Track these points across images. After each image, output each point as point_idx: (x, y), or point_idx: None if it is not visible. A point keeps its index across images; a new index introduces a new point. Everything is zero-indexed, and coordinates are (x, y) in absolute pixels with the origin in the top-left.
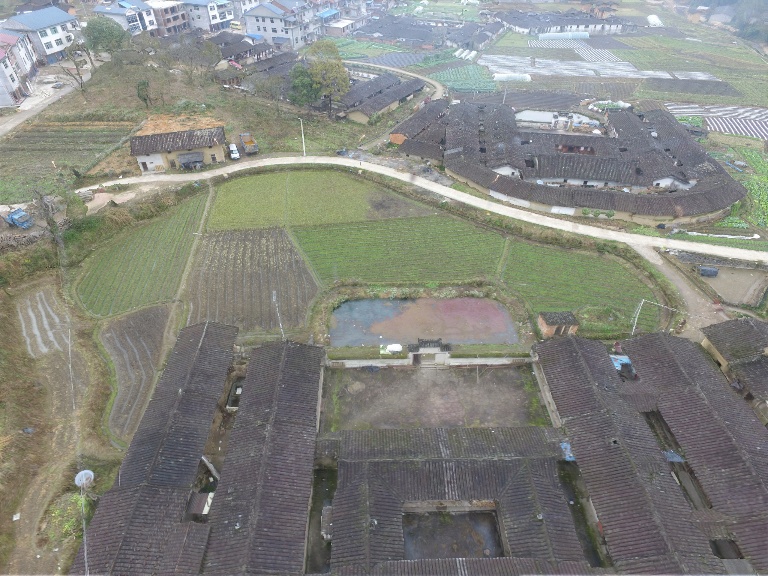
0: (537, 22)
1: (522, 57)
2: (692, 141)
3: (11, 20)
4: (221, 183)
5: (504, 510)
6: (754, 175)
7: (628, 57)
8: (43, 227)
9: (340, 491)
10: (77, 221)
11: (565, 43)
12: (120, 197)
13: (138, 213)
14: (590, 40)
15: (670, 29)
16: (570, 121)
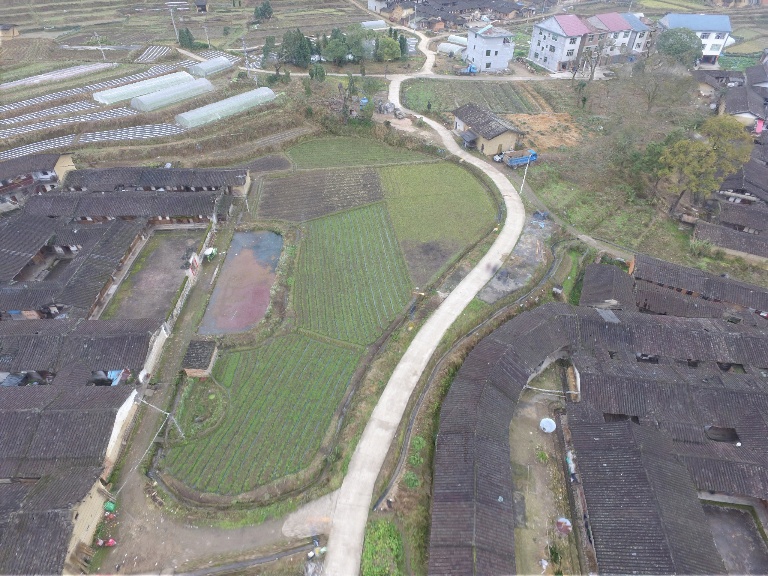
0: None
1: None
2: None
3: (667, 16)
4: (452, 162)
5: None
6: None
7: None
8: None
9: None
10: (363, 118)
11: None
12: (408, 127)
13: (389, 137)
14: None
15: None
16: None
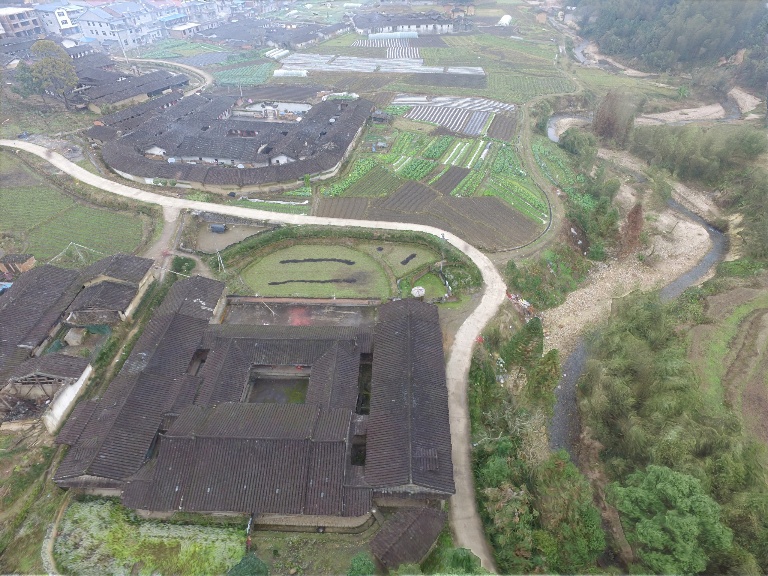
0: (371, 23)
1: (328, 55)
2: (350, 125)
3: None
4: None
5: None
6: (381, 154)
7: (429, 54)
8: None
9: None
10: None
11: (388, 42)
12: None
13: None
14: (416, 39)
15: (508, 28)
16: (276, 110)
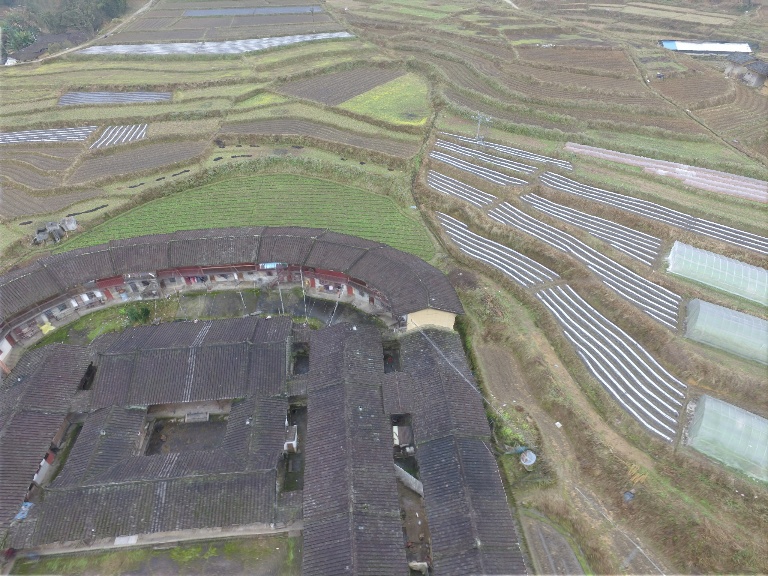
0: None
1: None
2: None
3: None
4: None
5: (131, 447)
6: None
7: None
8: None
9: (277, 450)
10: None
11: None
12: None
13: None
14: None
15: None
16: None
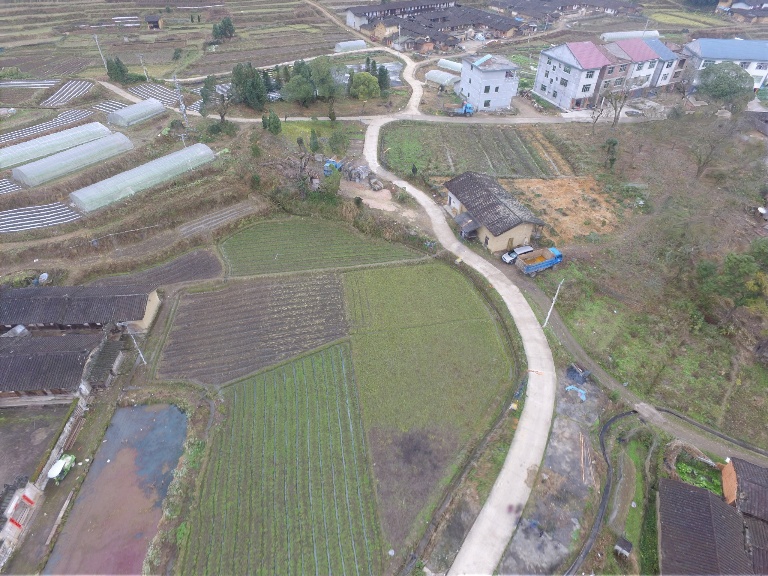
0: None
1: None
2: None
3: (697, 41)
4: (445, 262)
5: None
6: None
7: None
8: None
9: None
10: (327, 191)
11: None
12: (387, 204)
13: (360, 221)
14: None
15: None
16: None
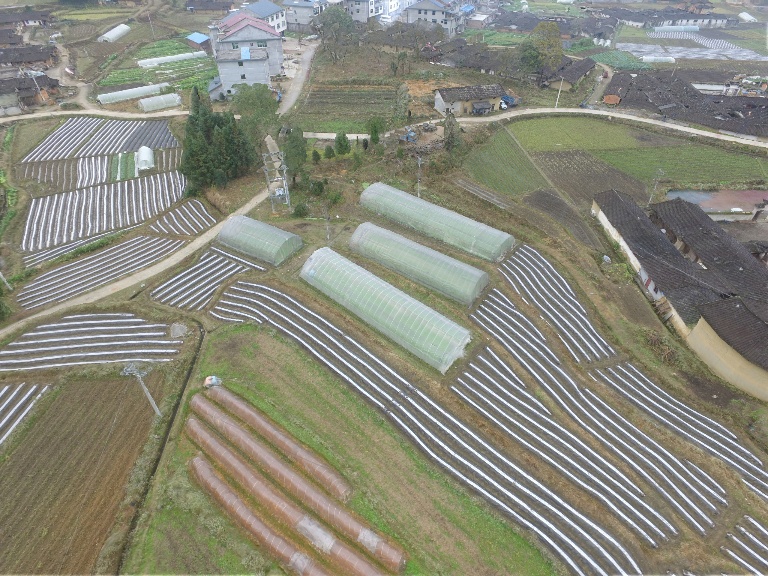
0: (651, 17)
1: (652, 45)
2: None
3: (245, 9)
4: (508, 124)
5: None
6: None
7: (745, 46)
8: (446, 139)
9: None
10: None
11: (681, 35)
12: None
13: (475, 139)
14: (701, 32)
15: (767, 24)
16: (740, 89)
